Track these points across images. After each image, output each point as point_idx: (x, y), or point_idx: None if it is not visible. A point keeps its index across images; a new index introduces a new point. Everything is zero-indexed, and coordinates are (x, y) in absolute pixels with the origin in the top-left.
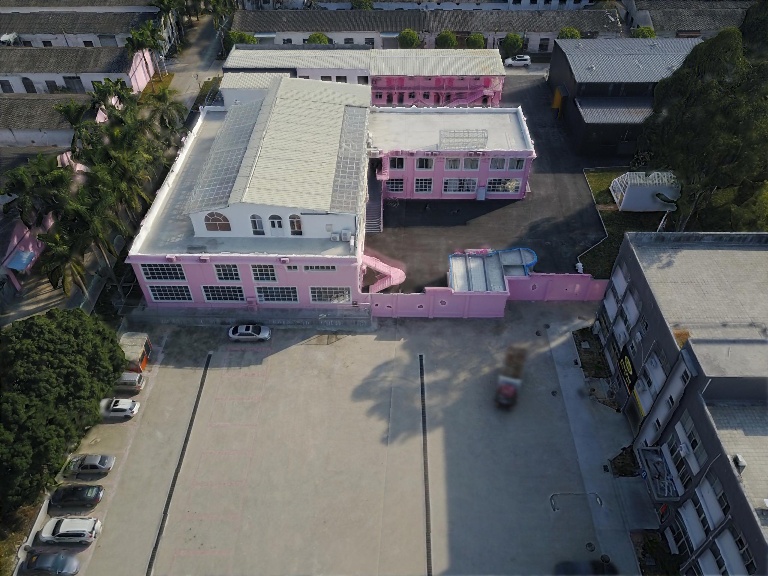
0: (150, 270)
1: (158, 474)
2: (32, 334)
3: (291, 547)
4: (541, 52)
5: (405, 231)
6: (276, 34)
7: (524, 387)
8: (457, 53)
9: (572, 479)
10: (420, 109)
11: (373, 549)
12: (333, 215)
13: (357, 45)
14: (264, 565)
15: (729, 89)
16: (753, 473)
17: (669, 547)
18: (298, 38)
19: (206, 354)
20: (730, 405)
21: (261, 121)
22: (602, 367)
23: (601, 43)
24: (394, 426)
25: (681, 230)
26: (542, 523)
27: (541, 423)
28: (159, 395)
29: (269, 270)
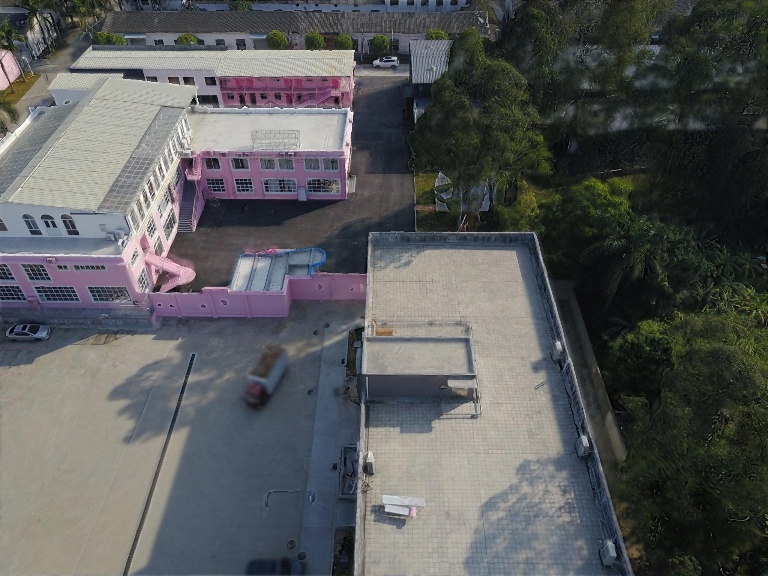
0: None
1: None
2: None
3: None
4: None
5: (217, 231)
6: (146, 35)
7: (283, 386)
8: (310, 54)
9: (297, 477)
10: (251, 110)
11: (78, 547)
12: (102, 215)
13: (213, 46)
14: None
15: (466, 90)
16: (390, 470)
17: None
18: (169, 39)
19: None
20: (399, 403)
21: (67, 121)
22: None
23: None
24: (142, 425)
25: None
26: (253, 521)
27: (287, 422)
28: None
29: (41, 270)
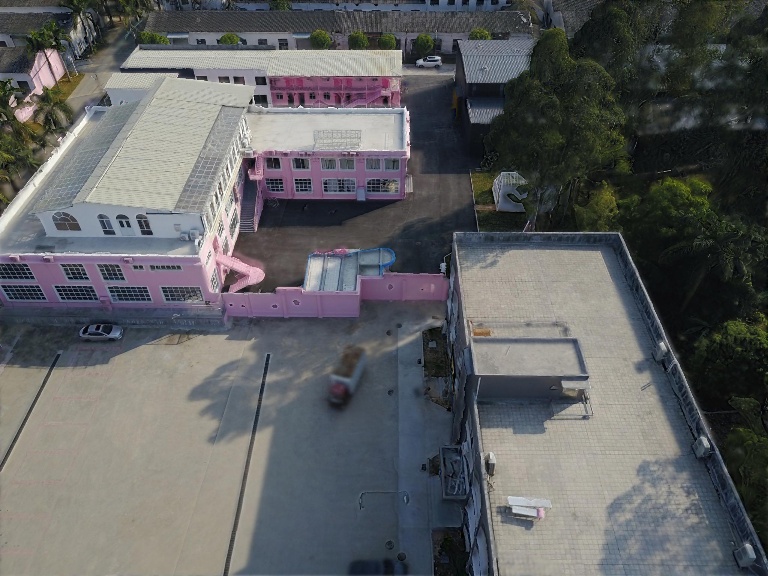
0: None
1: None
2: None
3: (94, 545)
4: (455, 53)
5: (279, 231)
6: (189, 35)
7: (362, 386)
8: (358, 54)
9: (388, 478)
10: (307, 109)
11: (175, 547)
12: (178, 215)
13: (261, 46)
14: (62, 563)
15: (552, 90)
16: (509, 471)
17: (465, 545)
18: (212, 39)
19: (55, 353)
20: (508, 403)
21: (131, 121)
22: (443, 366)
23: (501, 44)
24: (225, 425)
25: (531, 230)
26: (348, 521)
27: (370, 422)
28: None
29: (116, 270)
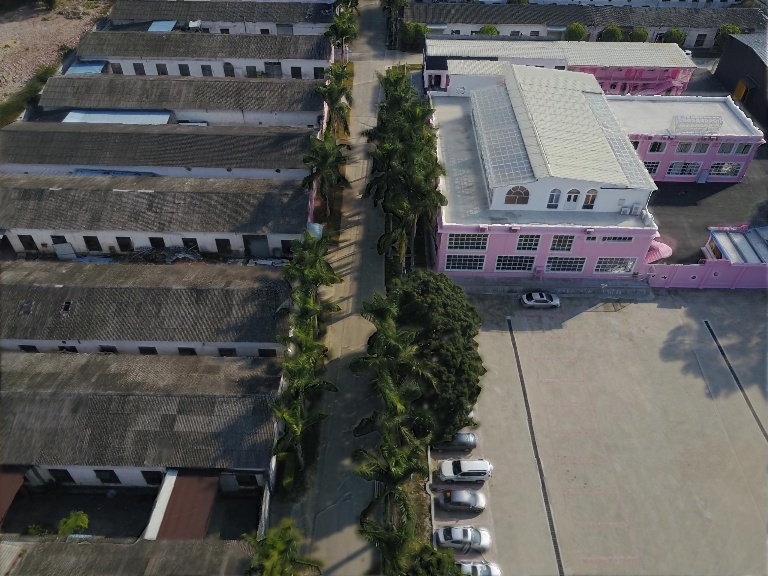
0: (455, 240)
1: (513, 424)
2: (431, 290)
3: (669, 486)
4: (696, 47)
5: None
6: (447, 26)
7: None
8: (642, 46)
9: None
10: (634, 97)
11: (743, 488)
12: (631, 190)
13: (543, 37)
14: (652, 501)
15: None
16: None
17: None
18: (466, 30)
19: (505, 319)
20: None
21: (518, 104)
22: None
23: None
24: (711, 383)
25: None
26: None
27: None
28: (480, 355)
29: (568, 241)
